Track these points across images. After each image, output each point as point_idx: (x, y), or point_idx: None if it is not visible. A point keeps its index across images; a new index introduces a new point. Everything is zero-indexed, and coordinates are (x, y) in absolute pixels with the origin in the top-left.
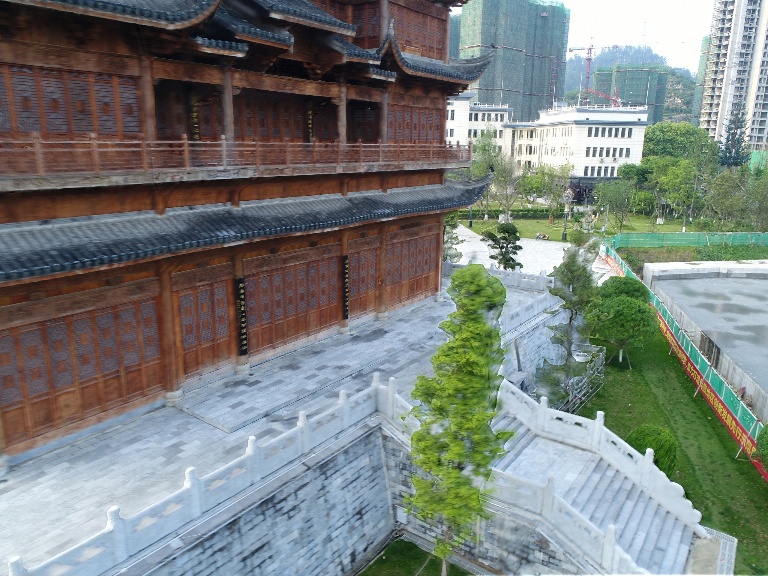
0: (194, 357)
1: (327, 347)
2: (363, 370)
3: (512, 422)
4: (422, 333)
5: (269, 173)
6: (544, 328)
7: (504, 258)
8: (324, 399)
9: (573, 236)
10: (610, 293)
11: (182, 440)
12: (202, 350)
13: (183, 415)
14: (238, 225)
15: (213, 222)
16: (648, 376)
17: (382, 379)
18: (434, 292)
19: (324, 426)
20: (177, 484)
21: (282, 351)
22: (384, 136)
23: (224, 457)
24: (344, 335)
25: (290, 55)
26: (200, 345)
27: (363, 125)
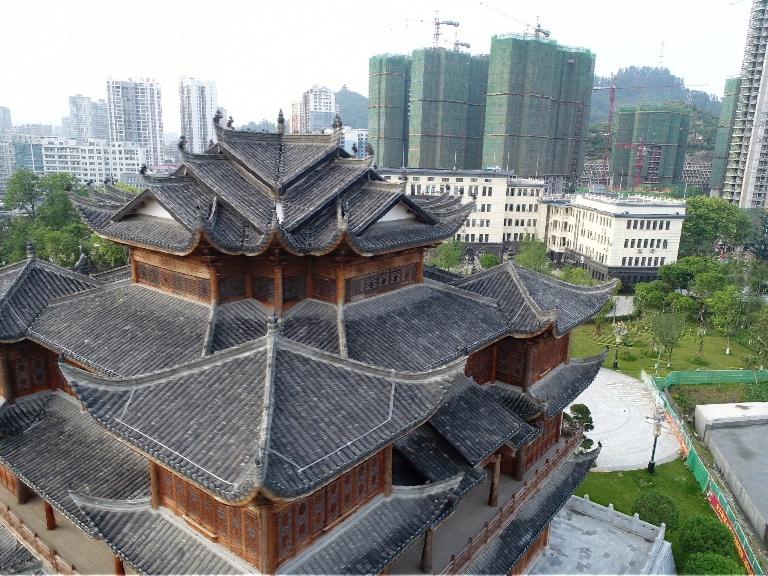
0: None
1: None
2: None
3: None
4: None
5: (459, 575)
6: None
7: None
8: None
9: None
10: (698, 538)
11: None
12: None
13: None
14: None
15: None
16: None
17: None
18: (543, 547)
19: None
20: None
21: None
22: (522, 459)
23: None
24: None
25: None
26: None
27: None
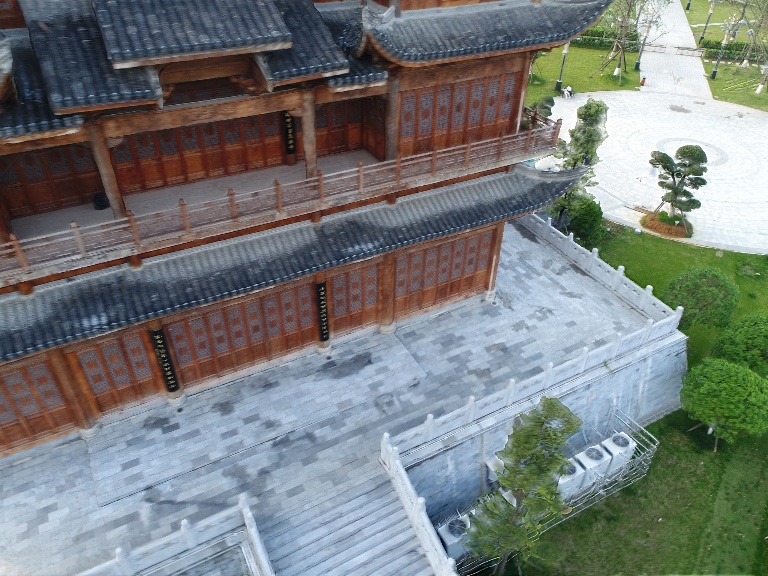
0: (110, 398)
1: (286, 377)
2: (294, 432)
3: (417, 560)
4: (406, 377)
5: (157, 245)
6: (587, 390)
7: (673, 193)
8: (218, 477)
9: (543, 400)
10: (737, 342)
11: (57, 502)
12: (119, 391)
13: (84, 459)
14: (119, 304)
15: (89, 301)
16: (730, 473)
17: (300, 457)
18: (482, 290)
19: (155, 553)
20: (8, 575)
21: (231, 378)
22: (391, 137)
23: (69, 547)
24: (320, 357)
25: (203, 73)
26: (116, 388)
27: (375, 109)
